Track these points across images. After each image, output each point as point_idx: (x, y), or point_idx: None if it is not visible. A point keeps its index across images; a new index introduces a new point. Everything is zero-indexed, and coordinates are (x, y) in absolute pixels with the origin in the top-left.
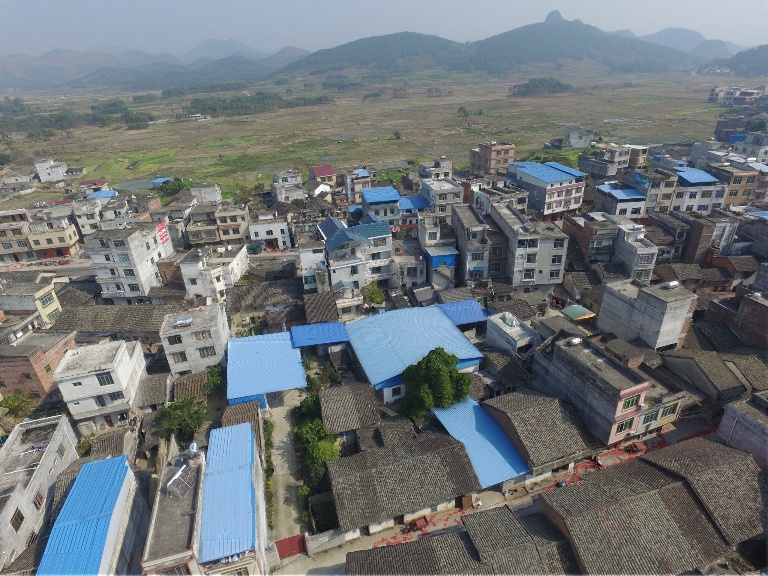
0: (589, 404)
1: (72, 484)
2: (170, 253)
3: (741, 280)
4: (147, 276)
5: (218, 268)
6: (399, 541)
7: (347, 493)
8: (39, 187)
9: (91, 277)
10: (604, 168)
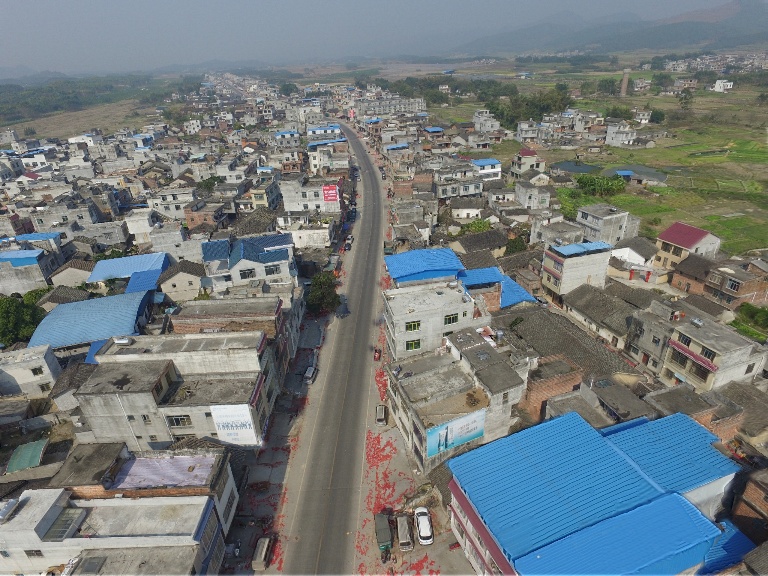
0: None
1: None
2: (335, 211)
3: None
4: None
5: None
6: None
7: None
8: None
9: None
10: None
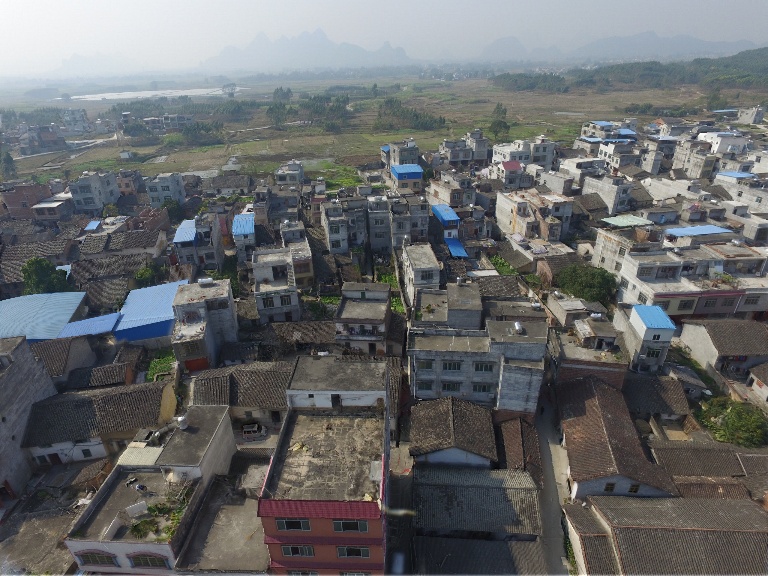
0: None
1: None
2: None
3: None
4: None
5: (162, 428)
6: None
7: None
8: None
9: (506, 569)
10: None
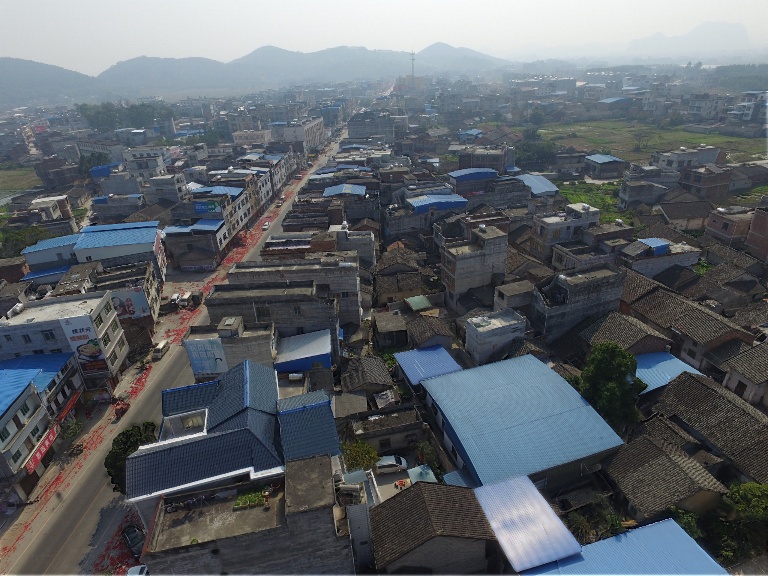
0: (604, 302)
1: None
2: None
3: (378, 236)
4: None
5: None
6: None
7: None
8: None
9: None
10: (67, 228)
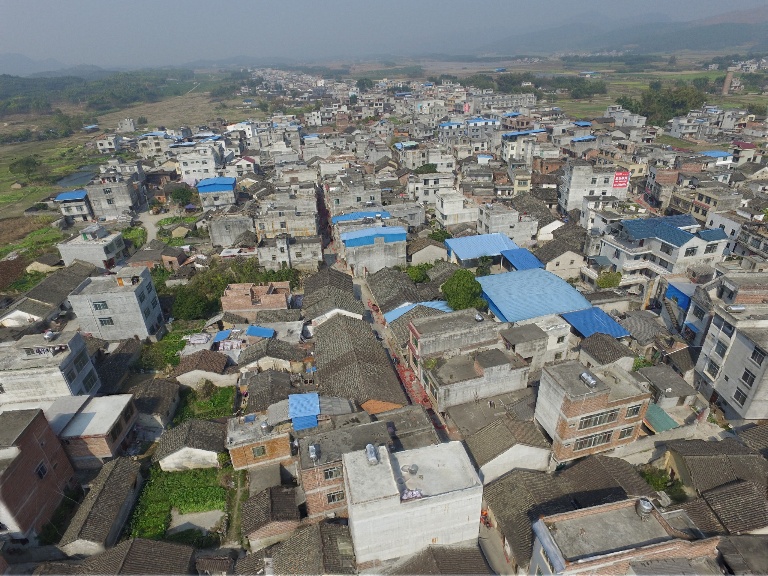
0: None
1: None
2: (620, 198)
3: None
4: (578, 200)
5: None
6: (369, 305)
7: (380, 273)
8: (759, 143)
9: None
10: None
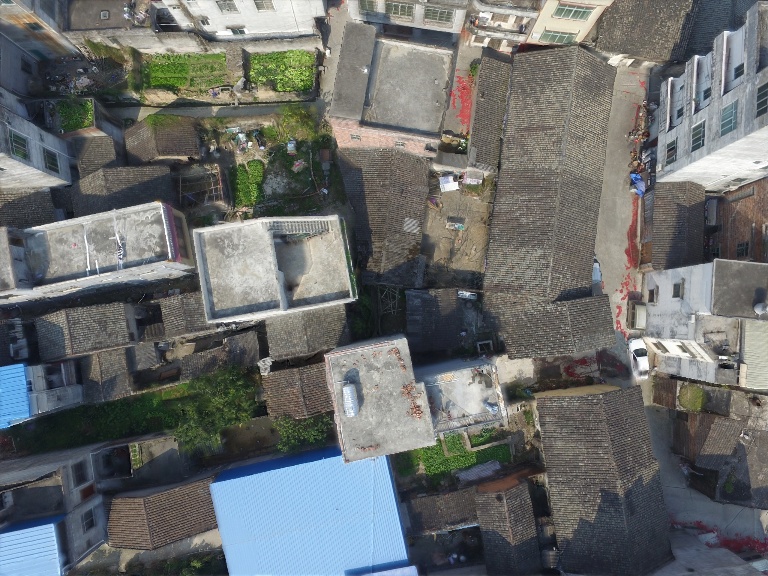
0: None
1: (59, 330)
2: None
3: None
4: (710, 171)
5: (709, 356)
6: None
7: None
8: None
9: None
10: None
